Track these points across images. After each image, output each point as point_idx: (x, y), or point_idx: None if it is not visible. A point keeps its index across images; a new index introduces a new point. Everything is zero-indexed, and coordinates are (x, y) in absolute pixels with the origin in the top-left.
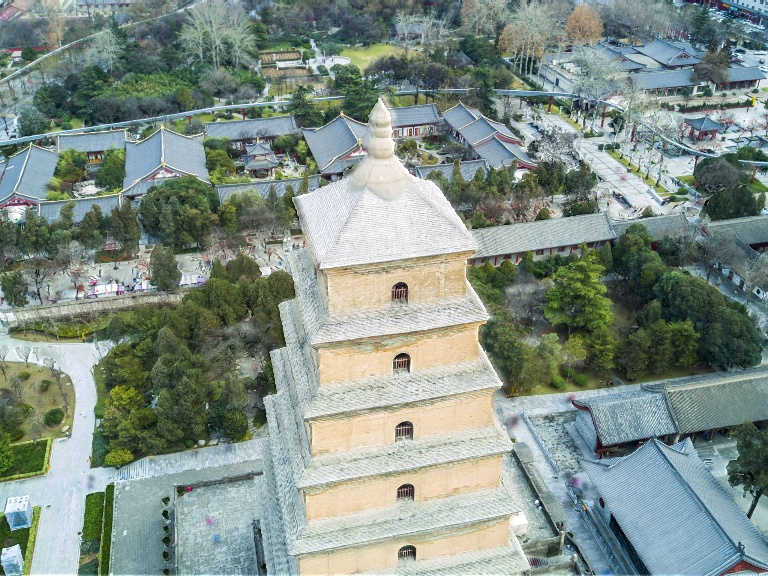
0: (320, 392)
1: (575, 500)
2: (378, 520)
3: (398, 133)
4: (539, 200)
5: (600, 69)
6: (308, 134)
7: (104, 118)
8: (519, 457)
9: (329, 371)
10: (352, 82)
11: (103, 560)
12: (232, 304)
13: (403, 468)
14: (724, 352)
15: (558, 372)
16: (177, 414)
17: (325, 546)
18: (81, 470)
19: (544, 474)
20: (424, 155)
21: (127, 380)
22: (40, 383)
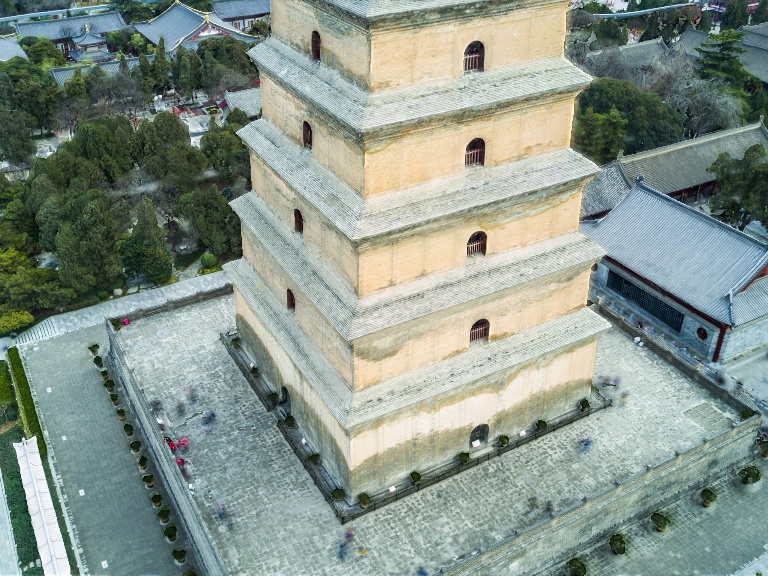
0: None
1: None
2: (448, 191)
3: (239, 26)
4: None
5: None
6: (141, 27)
7: None
8: None
9: None
10: None
11: (30, 419)
12: (114, 155)
13: (480, 104)
14: (653, 135)
15: None
16: (85, 252)
17: (393, 225)
18: None
19: None
20: None
21: (1, 242)
22: None
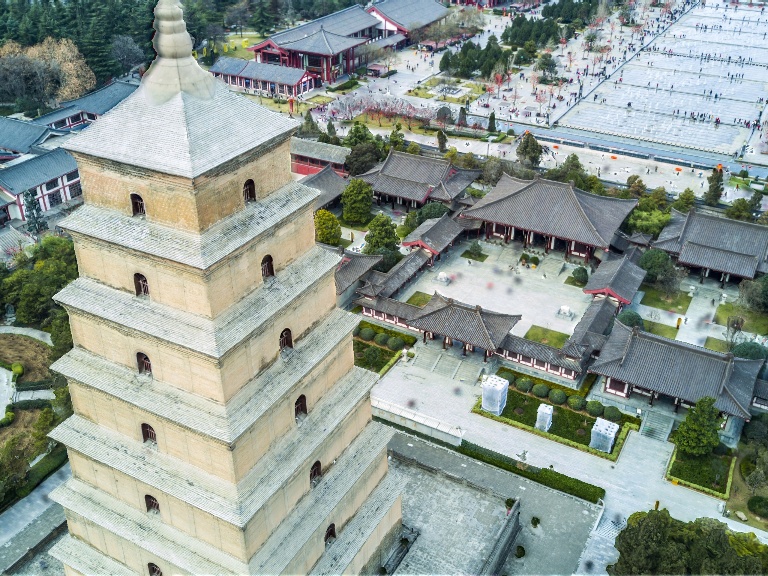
0: None
1: None
2: None
3: None
4: None
5: None
6: None
7: None
8: None
9: None
10: None
11: None
12: None
13: None
14: None
15: None
16: None
17: None
18: None
19: None
20: None
21: None
22: None
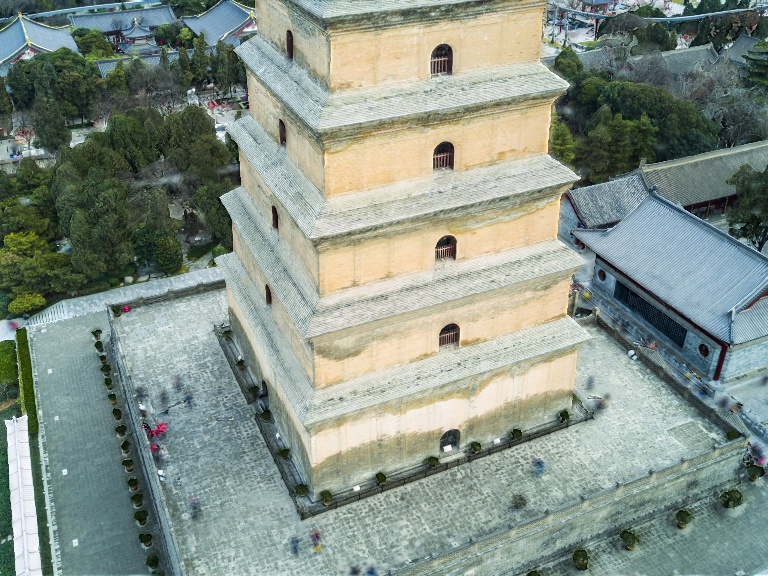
0: None
1: None
2: (413, 194)
3: None
4: None
5: None
6: (190, 21)
7: None
8: None
9: None
10: None
11: (26, 398)
12: (140, 146)
13: (445, 107)
14: (684, 144)
15: None
16: (96, 239)
17: (353, 225)
18: None
19: None
20: None
21: (23, 226)
22: None
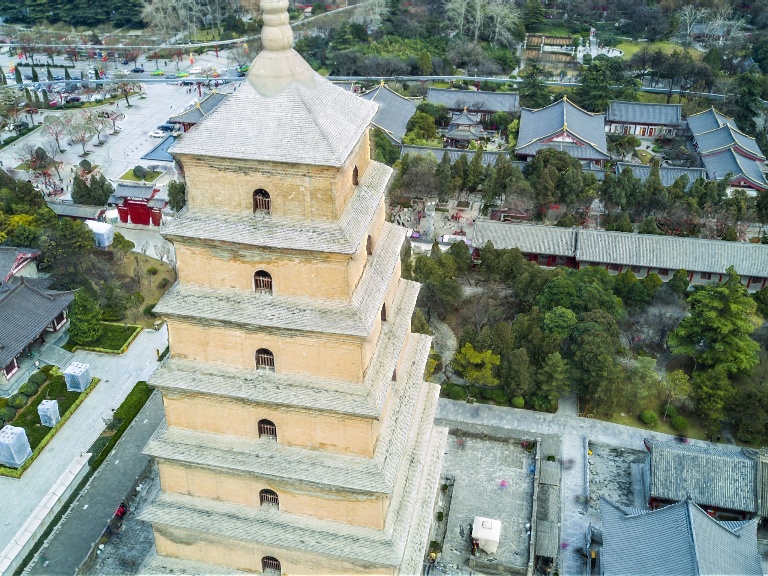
0: (178, 290)
1: (588, 543)
2: (235, 449)
3: (629, 130)
4: (756, 227)
5: None
6: (525, 114)
7: (344, 71)
8: (536, 473)
9: (188, 270)
10: (596, 69)
11: (113, 437)
12: None
13: (254, 398)
14: None
15: (658, 407)
16: None
17: (176, 456)
18: (149, 360)
19: (570, 505)
20: (646, 157)
21: None
22: (161, 280)
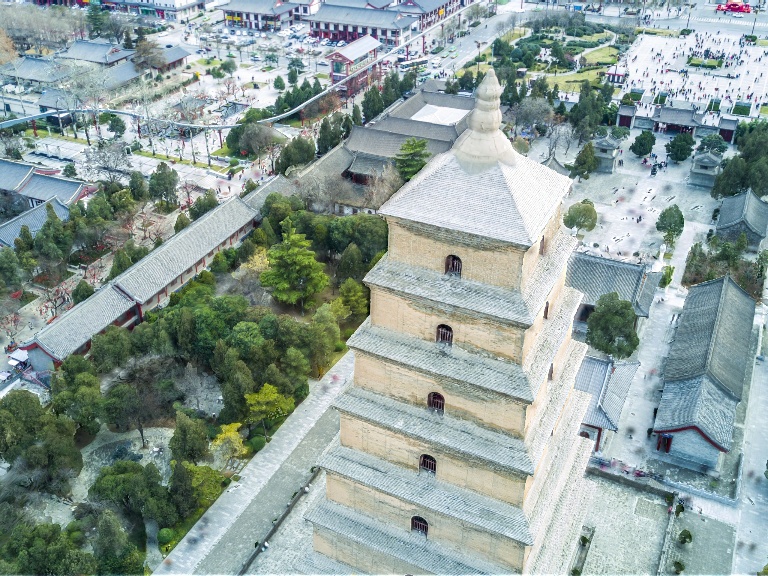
0: (525, 371)
1: None
2: (548, 469)
3: None
4: None
5: (89, 76)
6: None
7: None
8: None
9: None
10: None
11: None
12: None
13: None
14: None
15: None
16: None
17: None
18: None
19: None
20: None
21: None
22: None
